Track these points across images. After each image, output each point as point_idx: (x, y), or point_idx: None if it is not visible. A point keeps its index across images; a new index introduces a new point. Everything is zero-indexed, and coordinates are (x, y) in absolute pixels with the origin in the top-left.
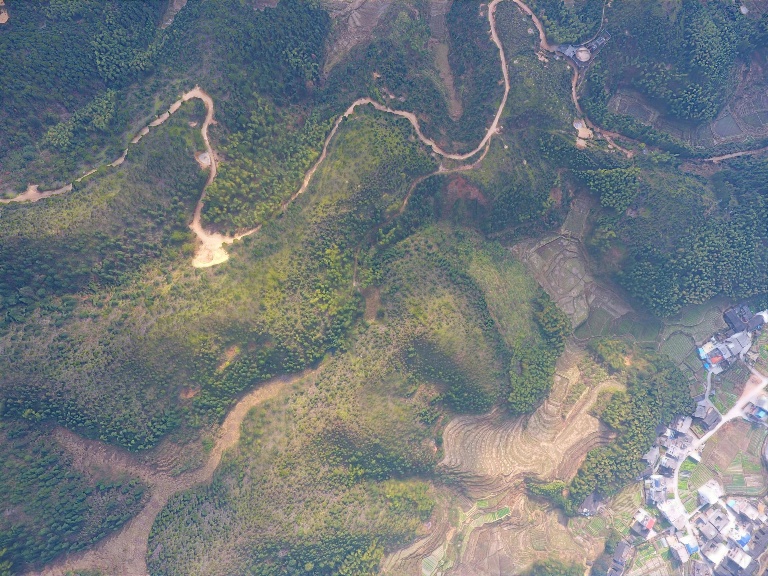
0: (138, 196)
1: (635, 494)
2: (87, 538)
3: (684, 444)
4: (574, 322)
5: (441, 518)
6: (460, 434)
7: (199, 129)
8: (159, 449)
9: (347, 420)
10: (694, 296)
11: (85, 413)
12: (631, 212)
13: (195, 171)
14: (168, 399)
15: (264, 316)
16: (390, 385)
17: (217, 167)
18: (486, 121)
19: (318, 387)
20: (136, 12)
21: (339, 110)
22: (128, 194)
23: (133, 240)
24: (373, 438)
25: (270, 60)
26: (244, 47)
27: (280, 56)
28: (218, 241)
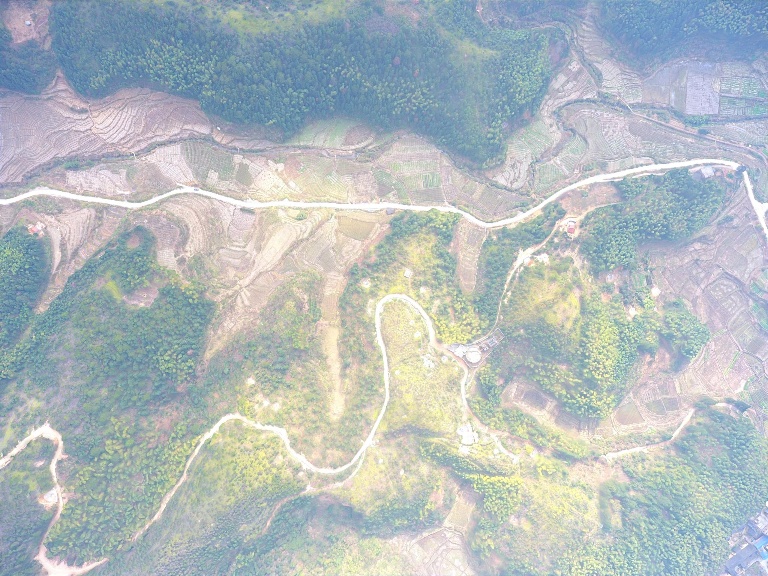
0: None
1: None
2: None
3: None
4: None
5: None
6: None
7: (47, 466)
8: None
9: None
10: None
11: None
12: (514, 518)
13: (37, 515)
14: None
15: None
16: None
17: None
18: (363, 431)
19: None
20: (7, 304)
21: (205, 426)
22: None
23: None
24: None
25: (138, 369)
26: (108, 363)
27: (150, 362)
28: (64, 572)
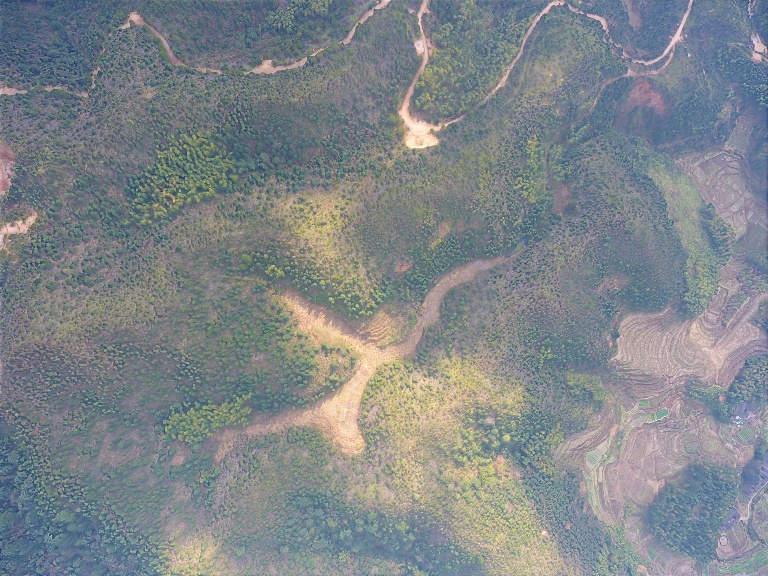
0: (365, 74)
1: None
2: (309, 396)
3: None
4: None
5: (609, 413)
6: (631, 333)
7: None
8: (375, 318)
9: (551, 299)
10: None
11: (322, 272)
12: None
13: (413, 56)
14: (386, 270)
15: (478, 195)
16: (583, 273)
17: (430, 55)
18: (670, 30)
19: (517, 271)
20: None
21: (535, 10)
22: (358, 71)
23: (359, 116)
24: (569, 321)
25: None
26: None
27: None
28: (424, 128)
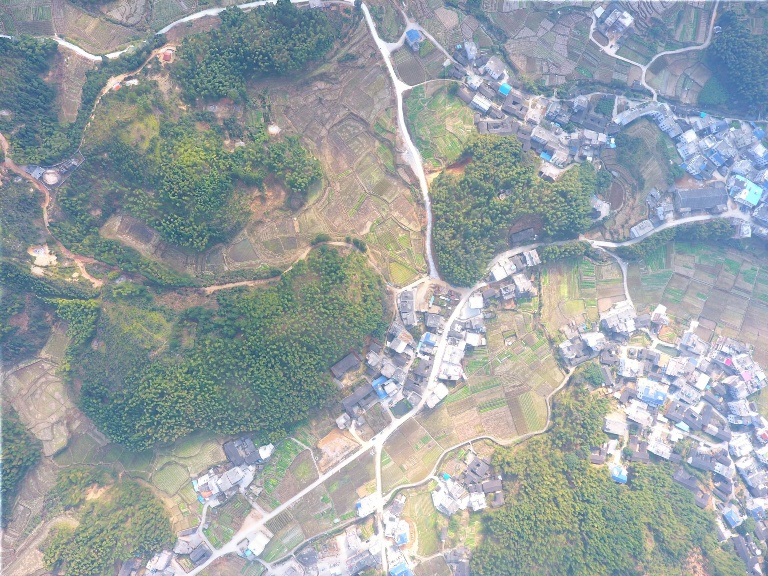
0: None
1: None
2: None
3: None
4: (51, 449)
5: None
6: None
7: None
8: None
9: None
10: (163, 433)
11: None
12: (96, 344)
13: None
14: None
15: None
16: None
17: None
18: None
19: None
20: None
21: None
22: None
23: None
24: None
25: None
26: None
27: None
28: None
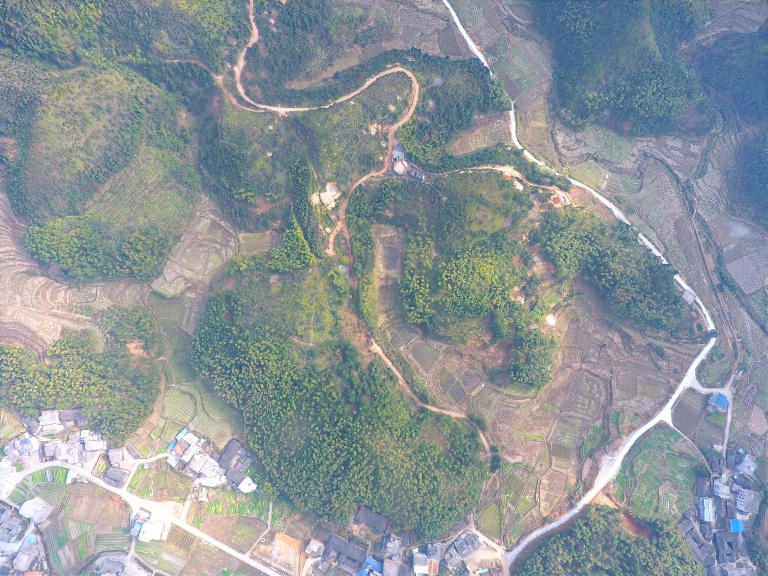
0: None
1: (10, 428)
2: None
3: (72, 449)
4: (159, 286)
5: None
6: None
7: None
8: None
9: None
10: (221, 382)
11: None
12: (276, 279)
13: None
14: None
15: None
16: None
17: None
18: (288, 103)
19: None
20: None
21: None
22: None
23: None
24: None
25: None
26: None
27: None
28: None
